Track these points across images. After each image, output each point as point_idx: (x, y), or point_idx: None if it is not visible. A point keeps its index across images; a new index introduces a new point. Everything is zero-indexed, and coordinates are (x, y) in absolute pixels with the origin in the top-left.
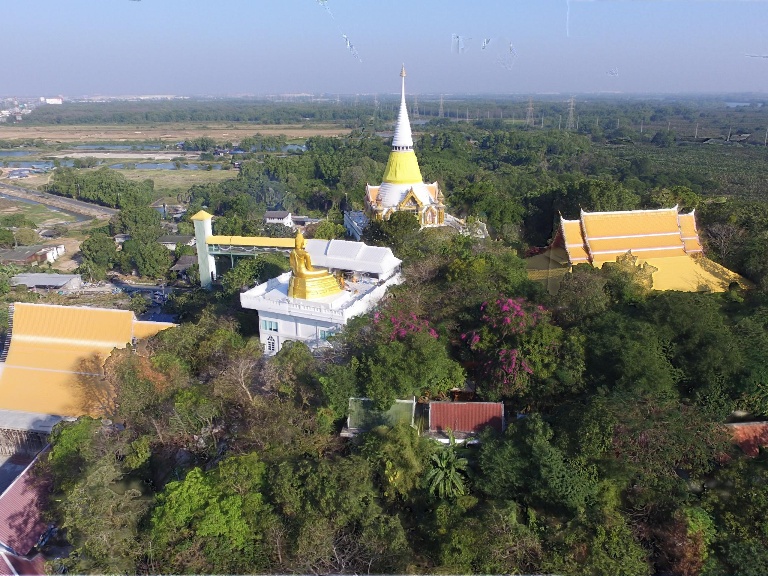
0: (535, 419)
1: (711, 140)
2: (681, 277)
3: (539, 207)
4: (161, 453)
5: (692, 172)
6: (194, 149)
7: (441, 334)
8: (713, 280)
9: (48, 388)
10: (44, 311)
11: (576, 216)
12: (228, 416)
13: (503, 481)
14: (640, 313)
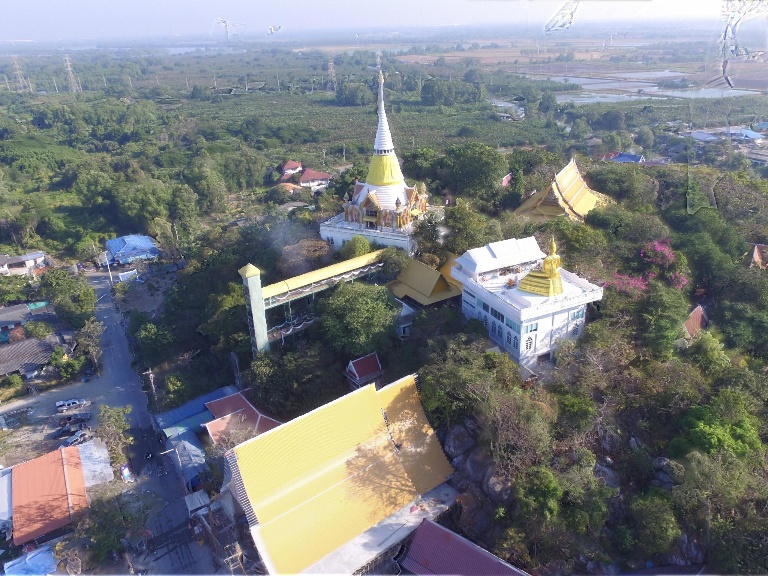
0: (737, 303)
1: (235, 90)
2: None
3: None
4: None
5: (299, 124)
6: None
7: (639, 281)
8: None
9: (330, 513)
10: (277, 436)
11: (473, 180)
12: None
13: (745, 344)
14: (688, 229)
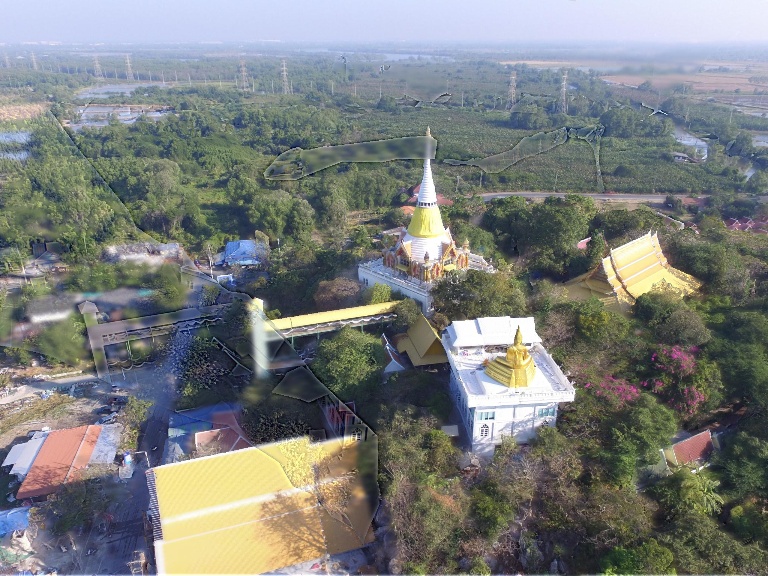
0: (753, 438)
1: (420, 103)
2: None
3: None
4: (461, 567)
5: (455, 145)
6: None
7: (637, 388)
8: (684, 284)
9: (234, 548)
10: (198, 466)
11: (544, 238)
12: None
13: (750, 488)
14: (737, 337)
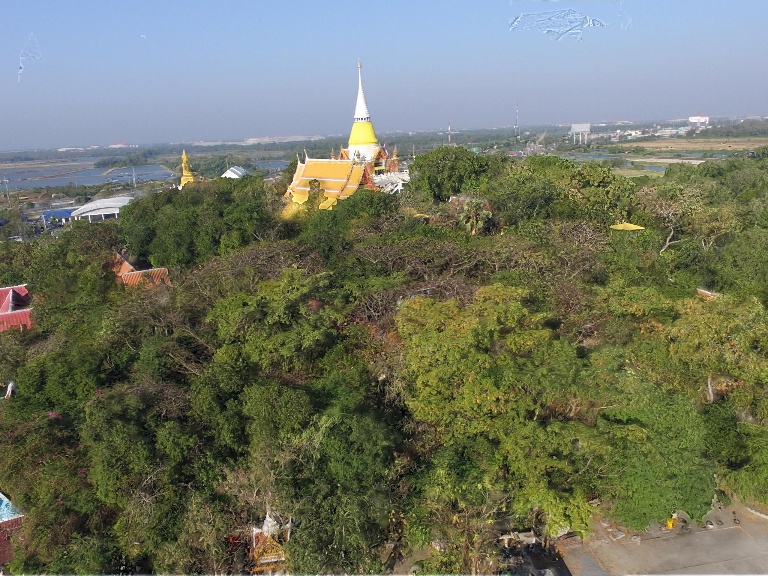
0: None
1: None
2: None
3: None
4: None
5: None
6: None
7: None
8: None
9: None
10: None
11: None
12: None
13: None
14: None
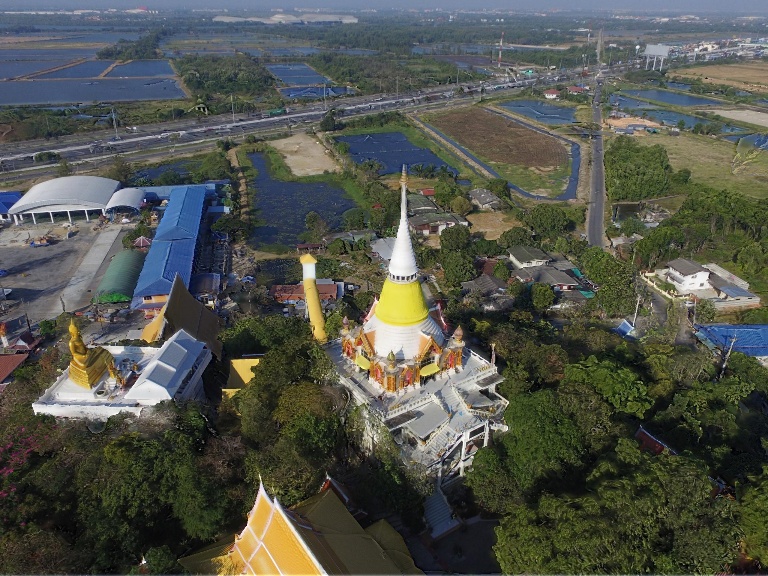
0: None
1: None
2: None
3: None
4: None
5: None
6: None
7: None
8: None
9: None
10: None
11: None
12: None
13: None
14: None
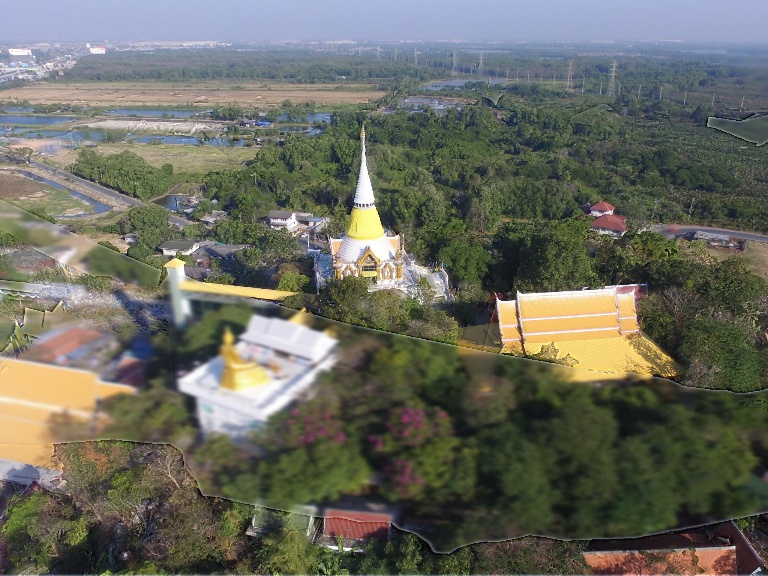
0: (408, 542)
1: (756, 115)
2: (610, 361)
3: (506, 254)
4: None
5: (716, 167)
6: (222, 118)
7: None
8: (643, 364)
9: None
10: None
11: (535, 271)
12: (163, 493)
13: None
14: None
